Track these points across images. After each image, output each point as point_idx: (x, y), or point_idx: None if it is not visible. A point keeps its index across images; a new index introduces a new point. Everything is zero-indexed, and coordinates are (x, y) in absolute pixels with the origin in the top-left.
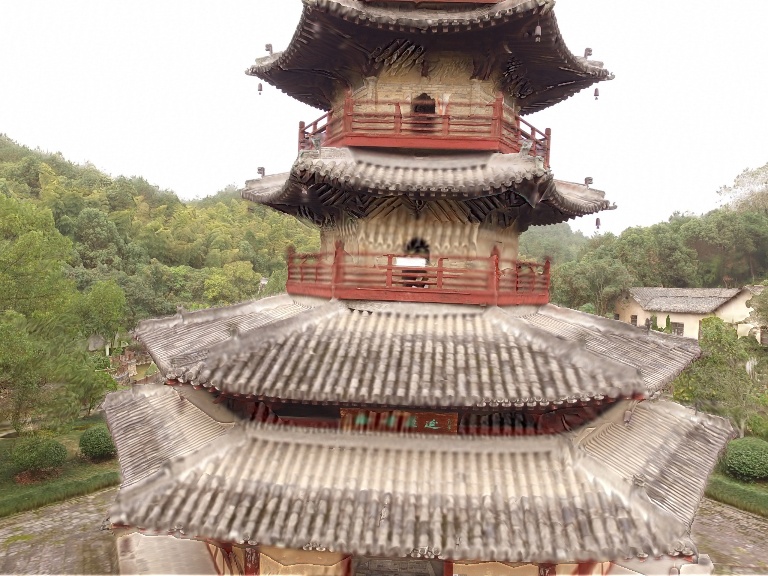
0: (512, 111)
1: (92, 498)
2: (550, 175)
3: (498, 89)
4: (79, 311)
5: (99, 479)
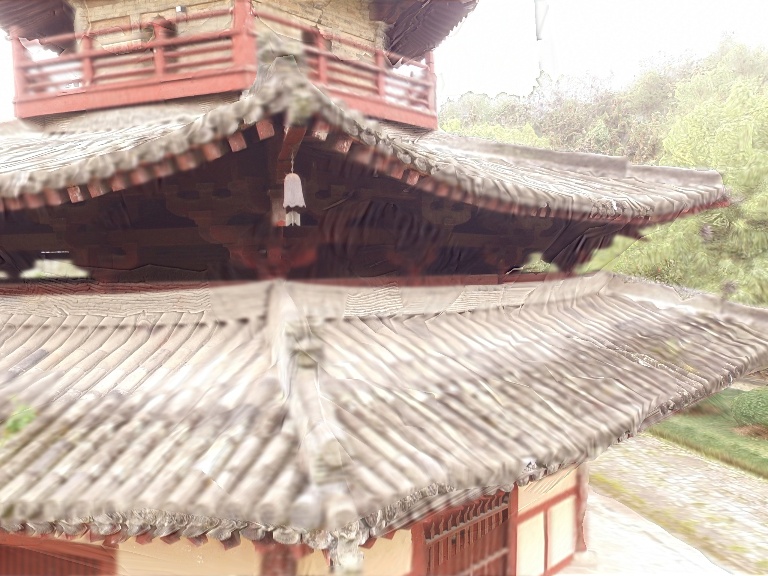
0: None
1: (679, 454)
2: None
3: None
4: None
5: (726, 448)
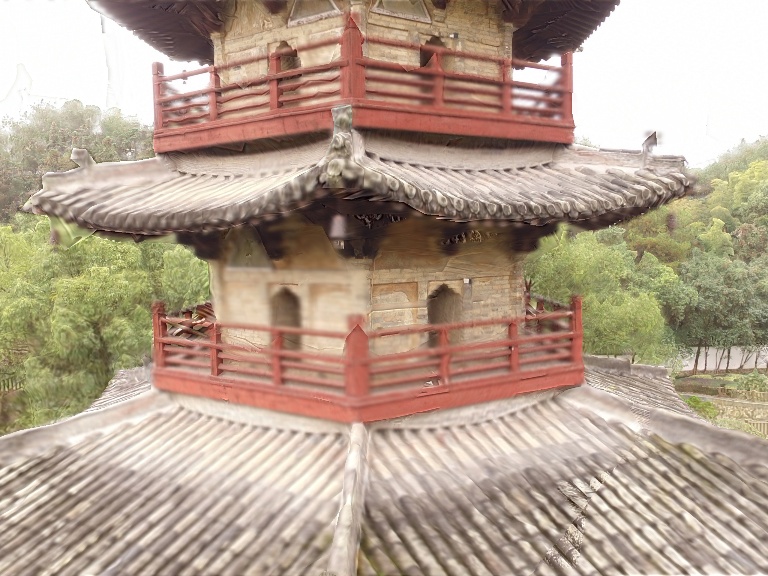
0: (337, 14)
1: None
2: (42, 199)
3: (268, 12)
4: (593, 326)
5: None
